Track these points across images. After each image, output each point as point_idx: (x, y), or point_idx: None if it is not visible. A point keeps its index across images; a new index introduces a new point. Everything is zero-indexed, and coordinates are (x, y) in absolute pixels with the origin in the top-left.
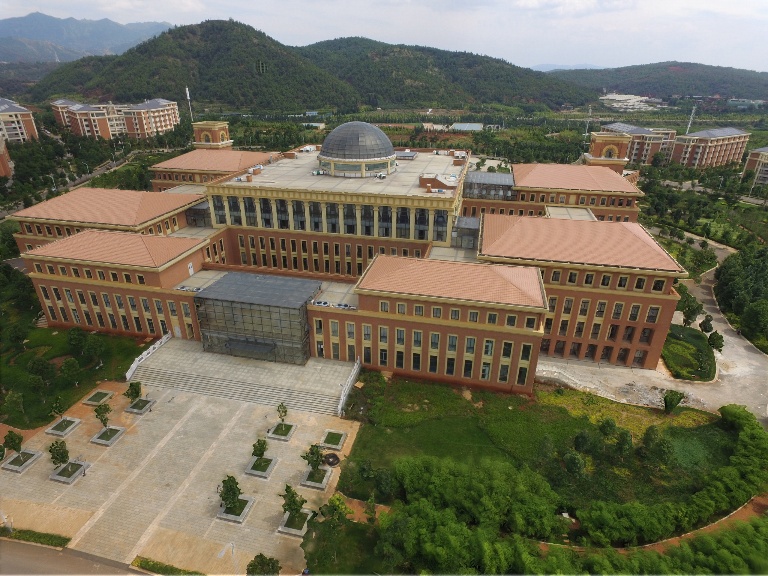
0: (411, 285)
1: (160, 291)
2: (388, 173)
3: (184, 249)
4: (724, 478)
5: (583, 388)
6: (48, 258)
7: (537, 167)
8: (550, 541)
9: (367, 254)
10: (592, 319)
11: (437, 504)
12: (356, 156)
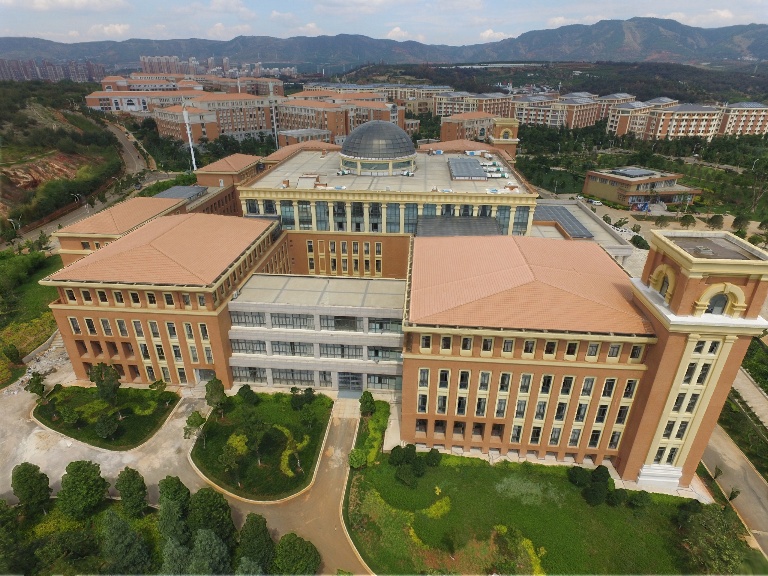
0: None
1: None
2: (358, 174)
3: (220, 170)
4: None
5: None
6: None
7: (494, 236)
8: None
9: None
10: None
11: None
12: None
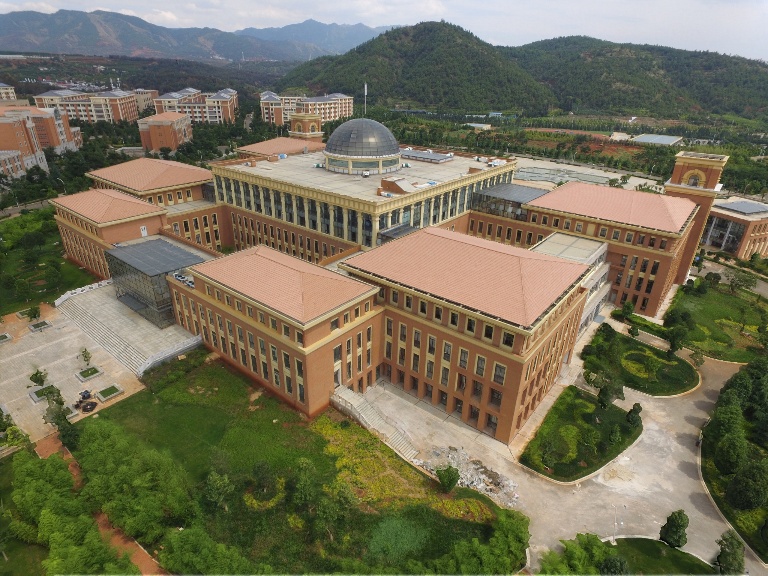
0: (227, 275)
1: (102, 243)
2: (379, 173)
3: (138, 214)
4: (355, 573)
5: (372, 430)
6: (58, 205)
7: (574, 186)
8: (143, 545)
9: (314, 248)
10: (439, 361)
11: (82, 468)
12: (345, 152)
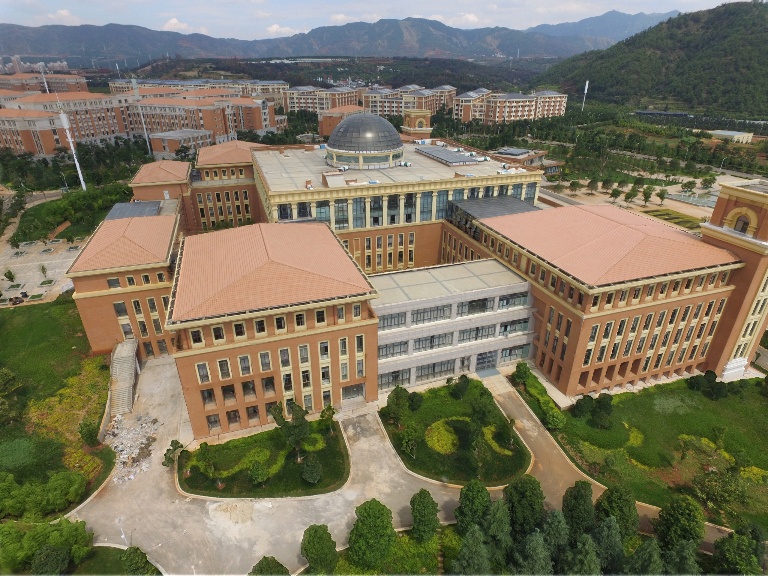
0: None
1: None
2: (359, 168)
3: (163, 180)
4: None
5: None
6: None
7: (558, 208)
8: None
9: None
10: None
11: None
12: (332, 145)
